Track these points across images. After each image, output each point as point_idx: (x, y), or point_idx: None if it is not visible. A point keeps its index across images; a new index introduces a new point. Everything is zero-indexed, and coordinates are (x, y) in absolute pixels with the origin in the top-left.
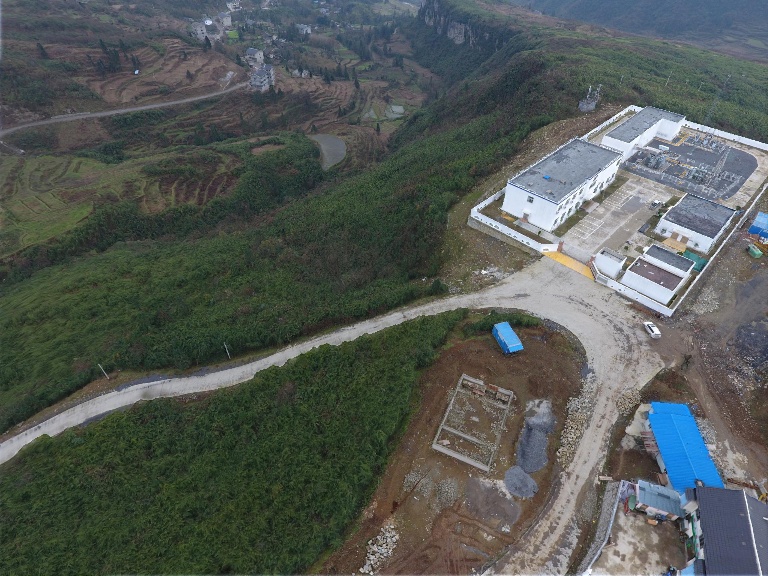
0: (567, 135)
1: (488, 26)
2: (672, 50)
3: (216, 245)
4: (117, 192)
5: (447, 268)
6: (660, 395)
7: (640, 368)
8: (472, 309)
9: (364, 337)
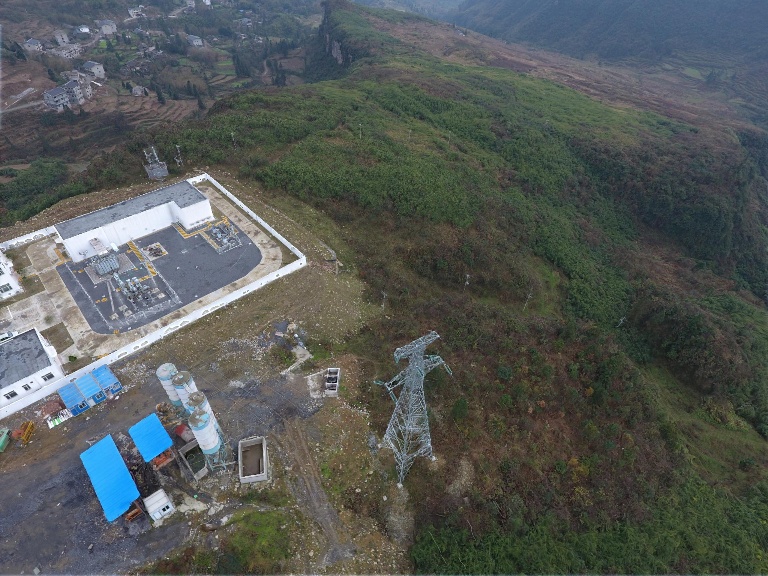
0: (67, 215)
1: (351, 47)
2: (497, 86)
3: None
4: None
5: None
6: None
7: None
8: None
9: None
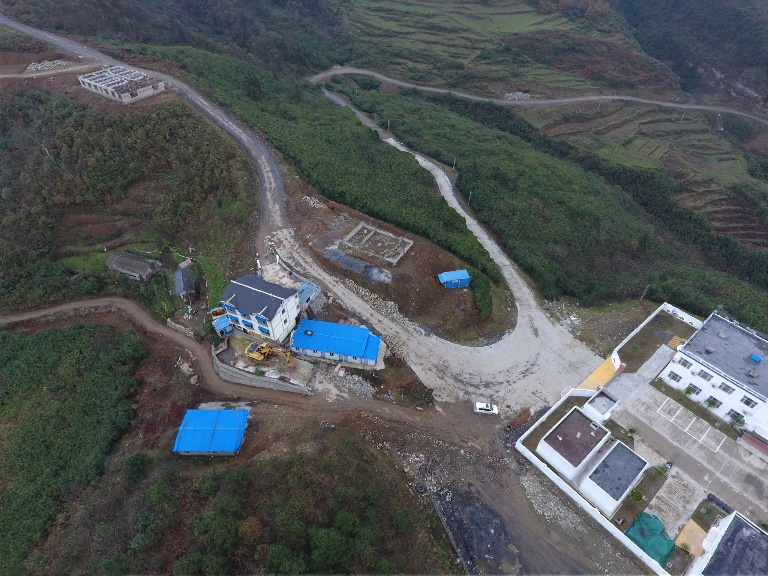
0: None
1: None
2: None
3: (623, 220)
4: (692, 178)
5: (587, 308)
6: (396, 365)
7: (433, 376)
8: (515, 299)
9: (470, 233)
